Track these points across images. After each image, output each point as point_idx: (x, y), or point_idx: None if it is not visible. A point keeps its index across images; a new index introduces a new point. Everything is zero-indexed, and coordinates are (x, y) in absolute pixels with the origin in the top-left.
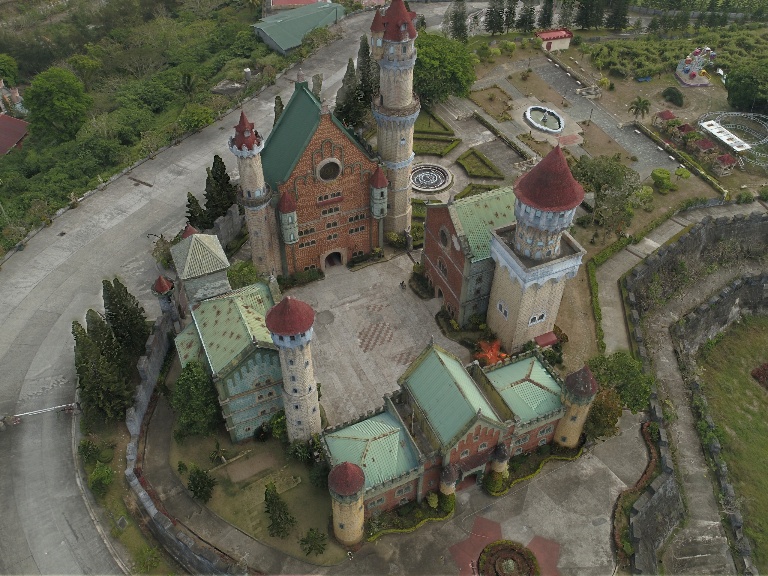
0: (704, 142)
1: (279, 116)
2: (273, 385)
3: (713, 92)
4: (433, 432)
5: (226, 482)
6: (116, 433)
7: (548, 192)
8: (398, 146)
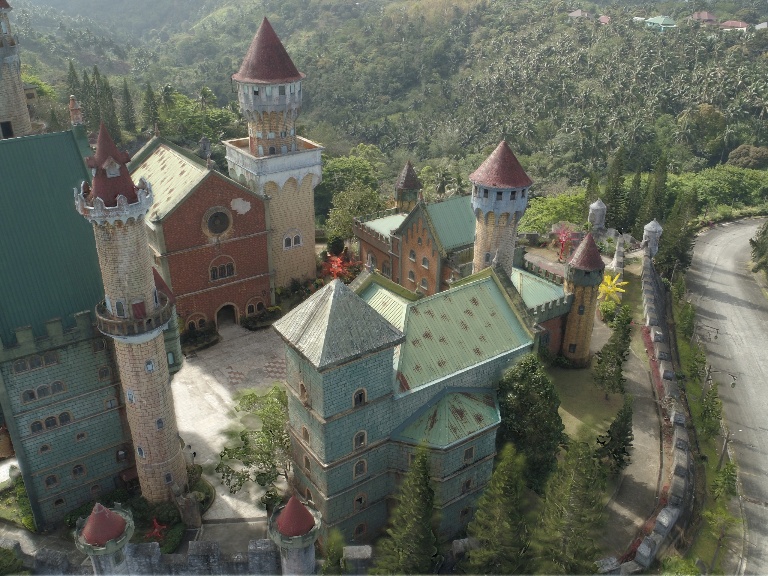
0: None
1: None
2: None
3: None
4: None
5: None
6: None
7: None
8: None
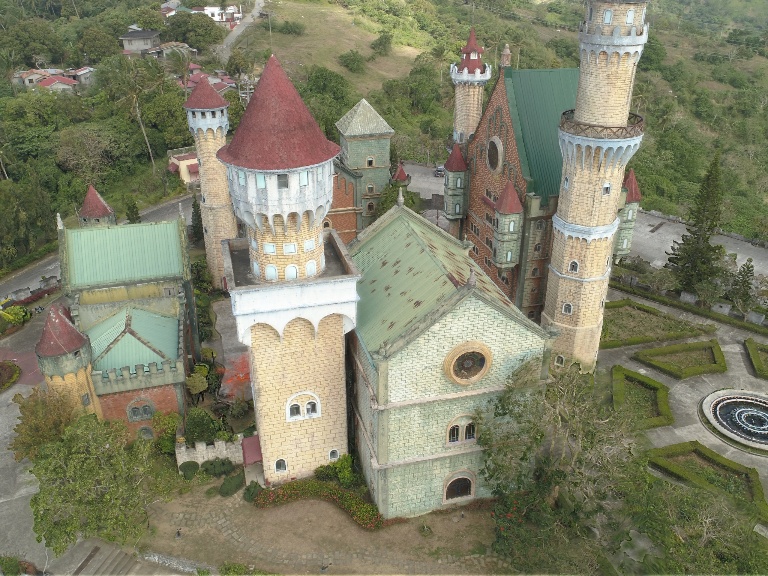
0: None
1: (703, 186)
2: None
3: None
4: None
5: None
6: None
7: None
8: (562, 187)
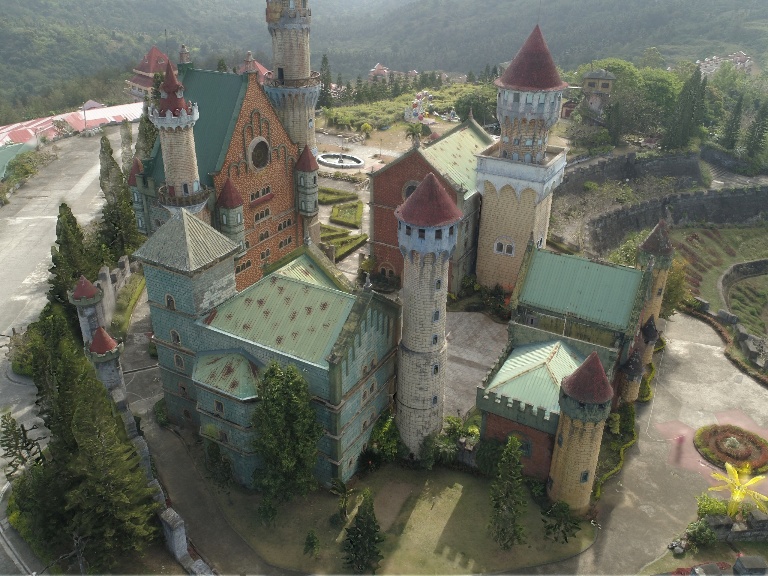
0: None
1: (109, 163)
2: (377, 369)
3: (444, 126)
4: (600, 324)
5: None
6: (147, 573)
7: (545, 73)
8: (307, 129)
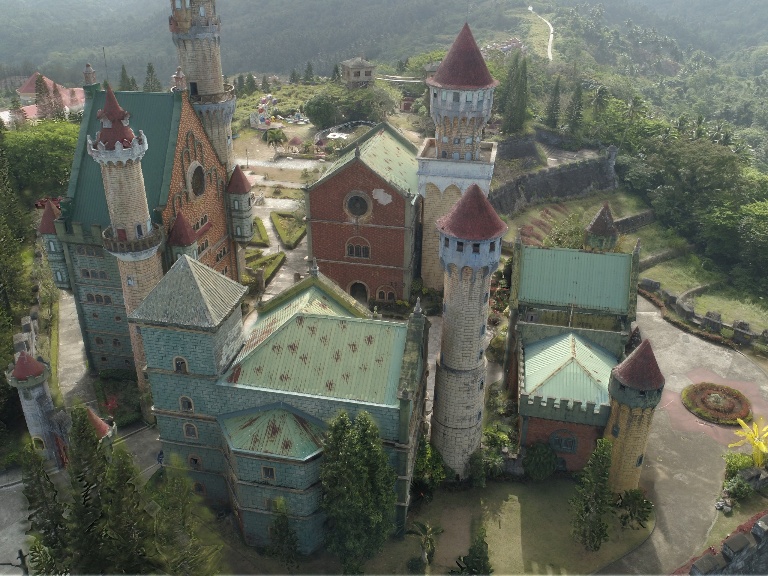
0: None
1: None
2: None
3: (293, 129)
4: (603, 310)
5: None
6: None
7: (481, 70)
8: (226, 147)
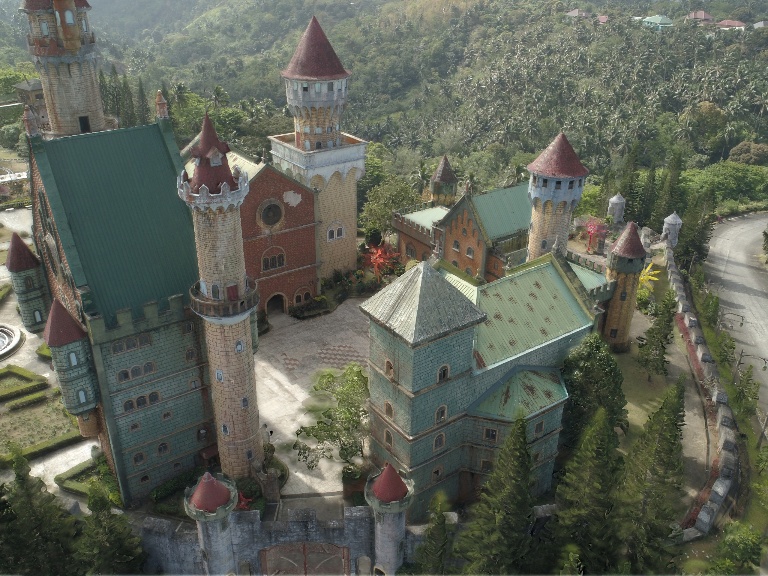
0: (0, 188)
1: None
2: None
3: None
4: None
5: (629, 436)
6: None
7: None
8: None
